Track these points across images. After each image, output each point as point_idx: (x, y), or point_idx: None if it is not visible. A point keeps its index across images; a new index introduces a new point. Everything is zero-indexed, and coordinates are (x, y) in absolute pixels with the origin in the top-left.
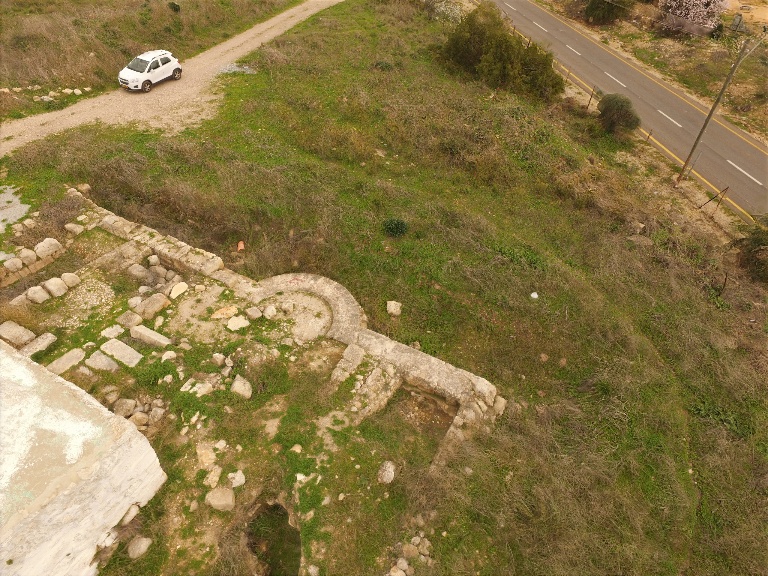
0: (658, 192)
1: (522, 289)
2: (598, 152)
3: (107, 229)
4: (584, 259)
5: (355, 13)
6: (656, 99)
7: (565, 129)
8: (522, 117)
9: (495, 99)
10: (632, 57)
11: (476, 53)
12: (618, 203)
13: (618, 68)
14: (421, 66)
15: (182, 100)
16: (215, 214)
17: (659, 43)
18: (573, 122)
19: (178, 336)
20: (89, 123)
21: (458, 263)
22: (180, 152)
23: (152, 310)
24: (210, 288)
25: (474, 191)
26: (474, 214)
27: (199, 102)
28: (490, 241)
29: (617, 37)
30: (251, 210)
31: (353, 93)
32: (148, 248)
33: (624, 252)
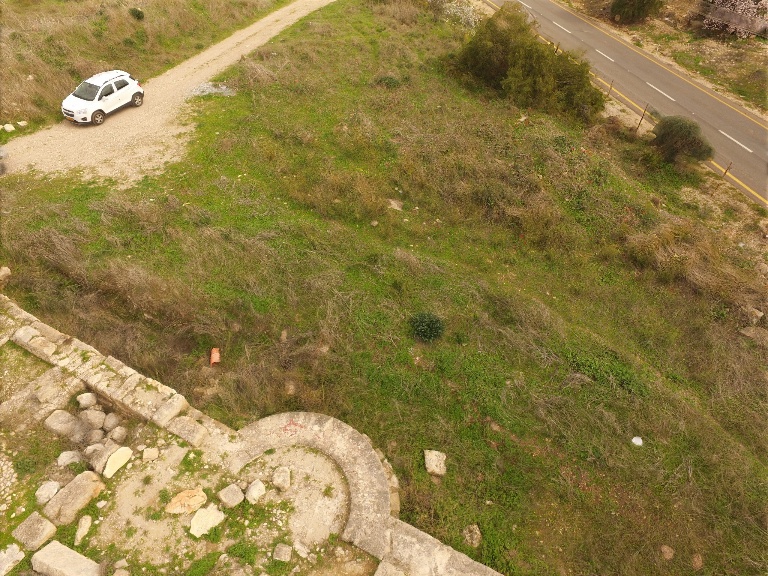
0: (744, 244)
1: (622, 435)
2: (659, 189)
3: (23, 346)
4: (690, 369)
5: (350, 15)
6: (713, 116)
7: (613, 158)
8: (569, 150)
9: (528, 123)
10: (672, 62)
11: (499, 65)
12: (717, 276)
13: (660, 77)
14: (433, 80)
15: (142, 135)
16: (179, 309)
17: (701, 45)
18: (621, 148)
19: (112, 555)
20: (19, 172)
21: (522, 389)
22: (134, 214)
23: (72, 509)
24: (166, 452)
25: (523, 260)
26: (528, 296)
27: (164, 137)
28: (558, 343)
29: (650, 38)
30: (228, 303)
31: (355, 120)
32: (78, 381)
33: (743, 356)
